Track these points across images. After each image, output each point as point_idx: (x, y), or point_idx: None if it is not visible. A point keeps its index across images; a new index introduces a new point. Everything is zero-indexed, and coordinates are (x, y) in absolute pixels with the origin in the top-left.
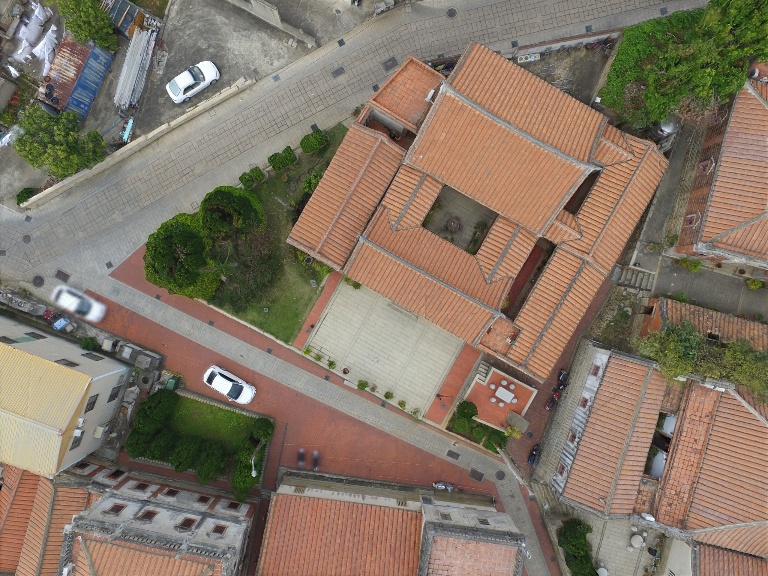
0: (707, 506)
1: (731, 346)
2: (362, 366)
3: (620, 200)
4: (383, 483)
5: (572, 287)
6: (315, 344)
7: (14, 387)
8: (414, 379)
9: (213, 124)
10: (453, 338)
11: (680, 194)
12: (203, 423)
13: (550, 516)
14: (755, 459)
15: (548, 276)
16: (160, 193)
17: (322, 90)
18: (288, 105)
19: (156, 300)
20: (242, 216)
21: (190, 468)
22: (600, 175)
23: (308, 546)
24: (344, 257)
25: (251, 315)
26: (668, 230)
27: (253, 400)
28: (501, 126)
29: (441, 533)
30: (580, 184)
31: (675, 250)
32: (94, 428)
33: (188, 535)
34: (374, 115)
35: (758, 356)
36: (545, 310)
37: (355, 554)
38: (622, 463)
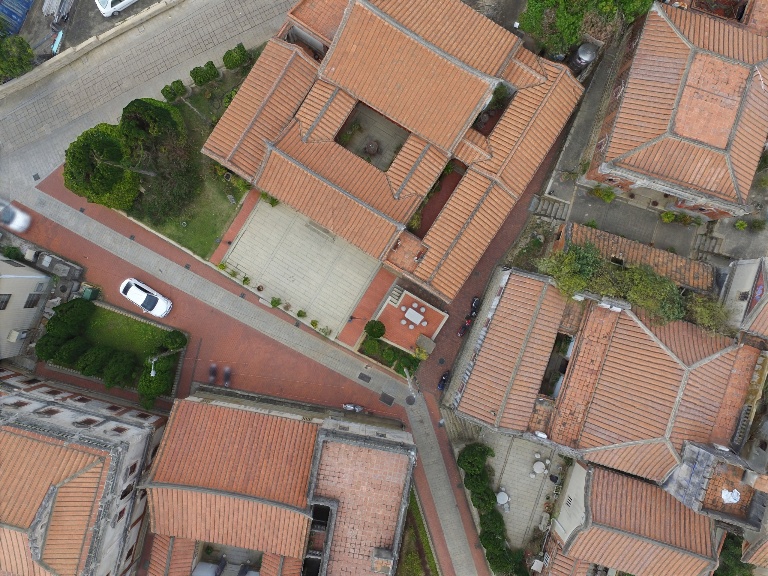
0: (599, 425)
1: (632, 269)
2: (277, 285)
3: (530, 122)
4: (294, 403)
5: (480, 207)
6: (232, 260)
7: None
8: (328, 300)
9: (142, 40)
10: (369, 261)
11: (596, 124)
12: (119, 334)
13: (456, 441)
14: (647, 379)
15: (458, 196)
16: (88, 107)
17: (249, 10)
18: (215, 23)
19: (80, 213)
20: (157, 123)
21: None
22: (514, 98)
23: (205, 450)
24: (256, 168)
25: (170, 229)
26: (583, 159)
27: (169, 314)
28: (410, 38)
29: (331, 437)
30: (487, 100)
31: (586, 176)
32: (9, 331)
33: (84, 429)
34: (297, 34)
35: (658, 280)
36: (453, 229)
37: (251, 460)
38: (514, 377)
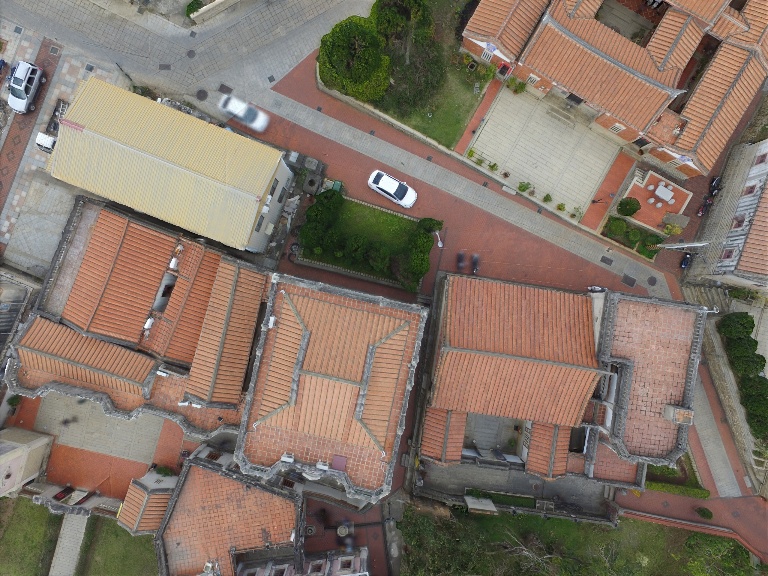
0: None
1: None
2: (521, 171)
3: None
4: None
5: (739, 78)
6: (476, 149)
7: (212, 157)
8: (571, 185)
9: None
10: (608, 146)
11: None
12: (366, 226)
13: None
14: None
15: (715, 69)
16: (324, 7)
17: None
18: None
19: (317, 112)
20: (422, 7)
21: (353, 270)
22: None
23: (488, 320)
24: (519, 48)
25: (415, 120)
26: None
27: (414, 205)
28: None
29: None
30: None
31: None
32: (266, 223)
33: None
34: None
35: None
36: (713, 100)
37: (533, 329)
38: None
